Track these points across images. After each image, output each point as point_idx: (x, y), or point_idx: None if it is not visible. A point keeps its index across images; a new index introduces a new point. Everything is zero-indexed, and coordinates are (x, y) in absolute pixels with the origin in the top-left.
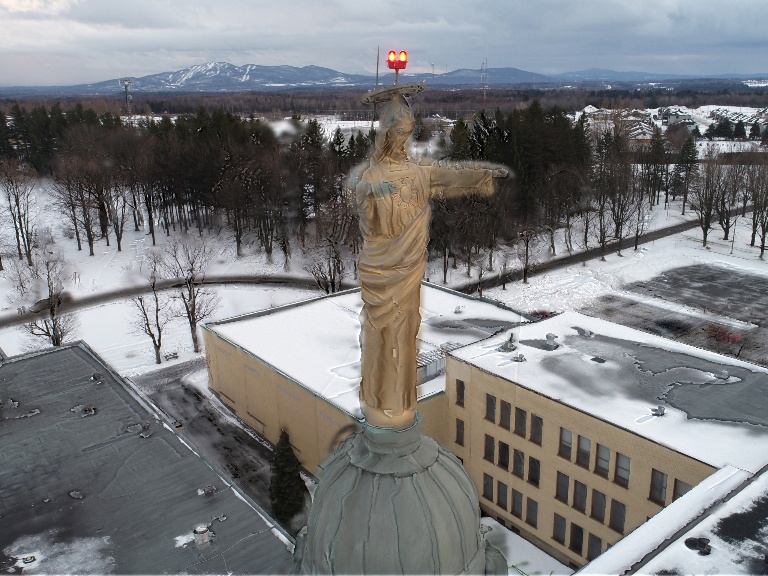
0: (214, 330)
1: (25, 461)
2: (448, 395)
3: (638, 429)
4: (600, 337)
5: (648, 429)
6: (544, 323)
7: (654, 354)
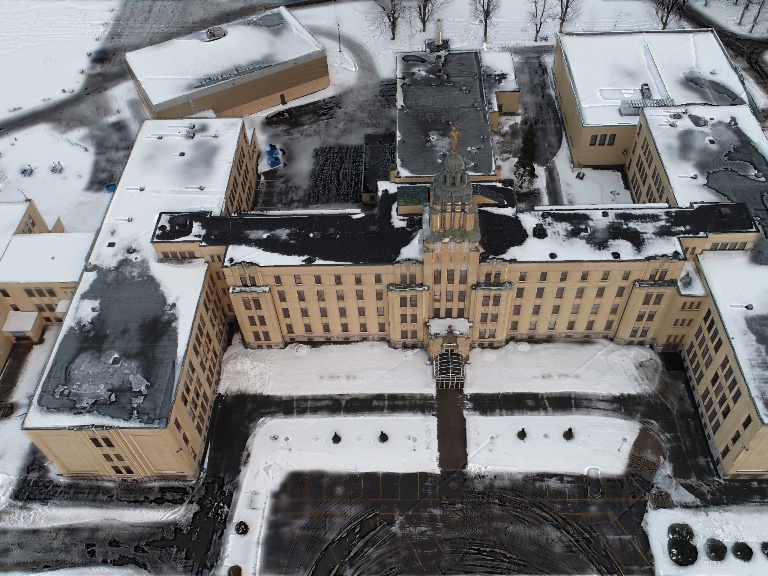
0: (561, 39)
1: (442, 105)
2: None
3: (673, 179)
4: (737, 129)
5: (677, 181)
6: (719, 108)
7: (748, 150)
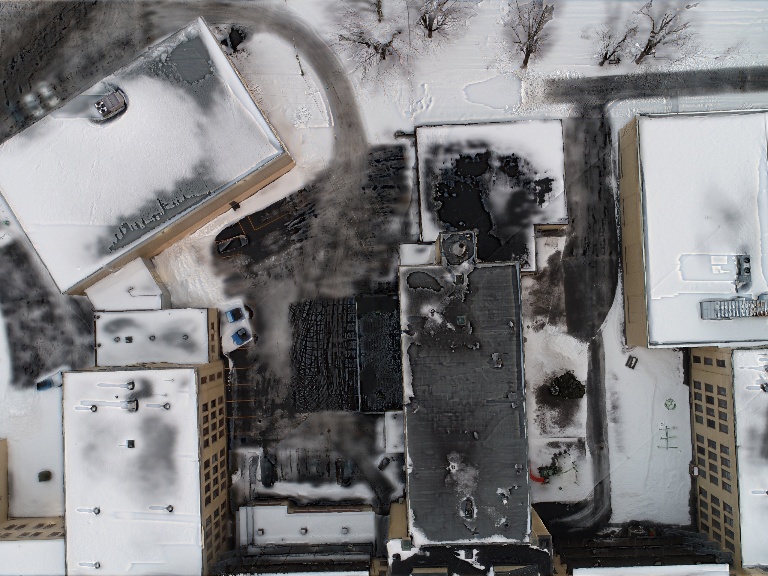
0: (641, 133)
1: (465, 396)
2: (718, 351)
3: (744, 498)
4: None
5: (749, 501)
6: None
7: None
